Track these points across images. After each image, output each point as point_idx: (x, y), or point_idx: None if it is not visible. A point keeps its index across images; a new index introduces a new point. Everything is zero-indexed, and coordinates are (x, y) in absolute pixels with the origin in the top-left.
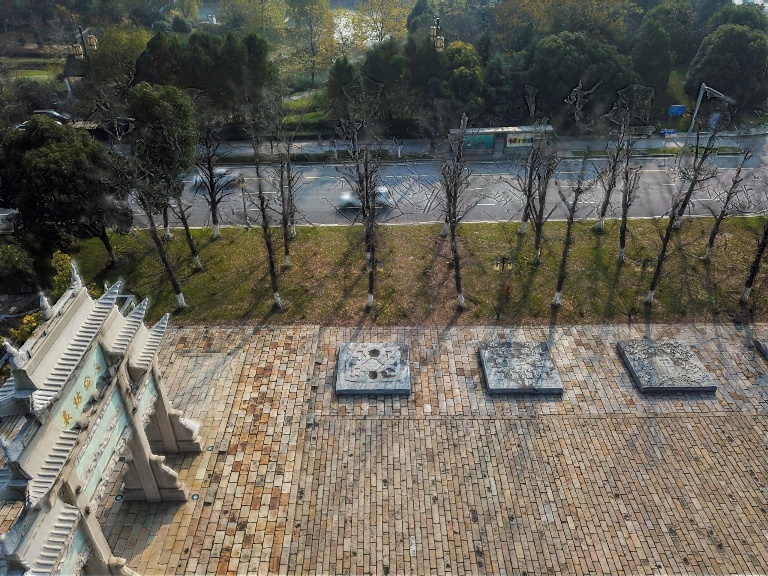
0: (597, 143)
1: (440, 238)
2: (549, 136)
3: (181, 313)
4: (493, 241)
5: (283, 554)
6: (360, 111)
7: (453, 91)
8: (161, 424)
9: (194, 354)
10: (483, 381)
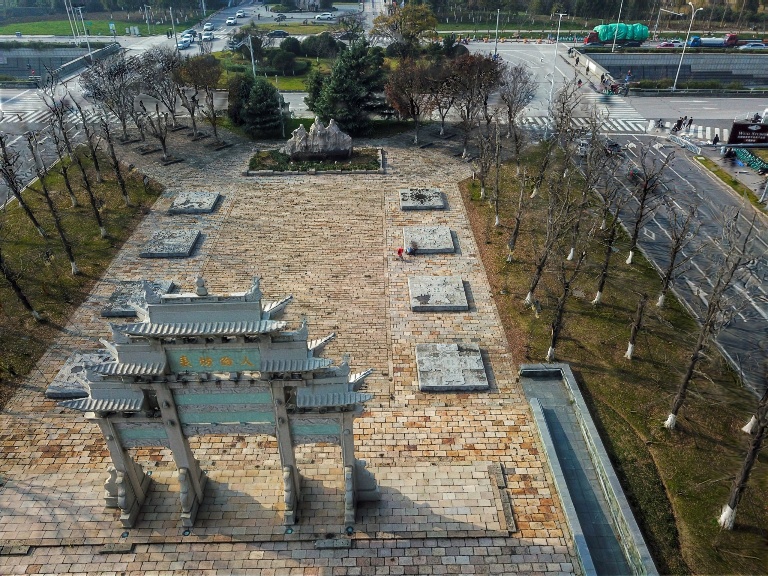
0: None
1: None
2: None
3: None
4: None
5: None
6: None
7: None
8: (132, 477)
9: None
10: None
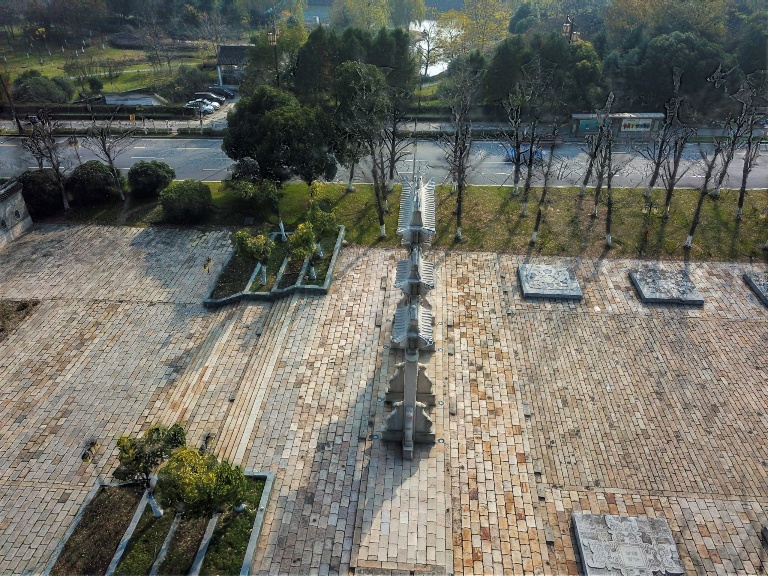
0: (701, 131)
1: (578, 197)
2: (660, 122)
3: (383, 240)
4: (624, 201)
5: (515, 385)
6: (535, 85)
7: (575, 81)
8: None
9: None
10: (637, 294)
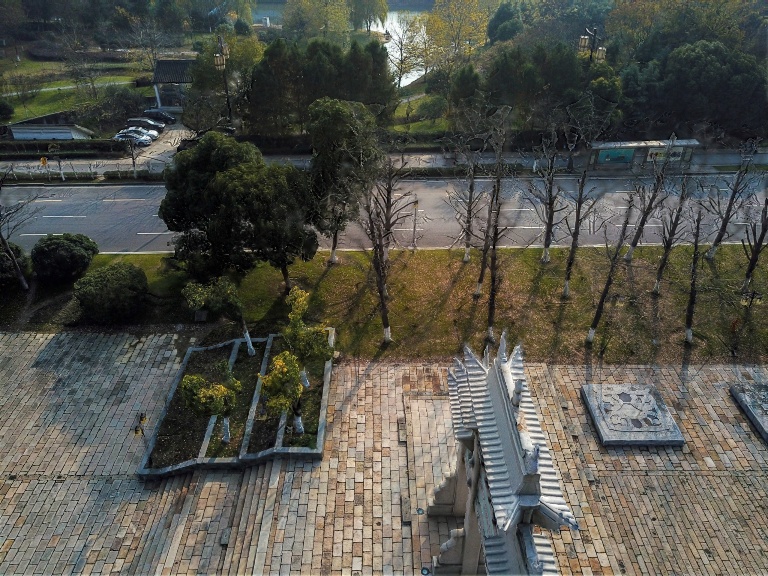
0: (735, 157)
1: (625, 263)
2: (693, 150)
3: (389, 348)
4: (684, 267)
5: None
6: (586, 132)
7: None
8: (460, 487)
9: (428, 397)
10: (755, 430)
